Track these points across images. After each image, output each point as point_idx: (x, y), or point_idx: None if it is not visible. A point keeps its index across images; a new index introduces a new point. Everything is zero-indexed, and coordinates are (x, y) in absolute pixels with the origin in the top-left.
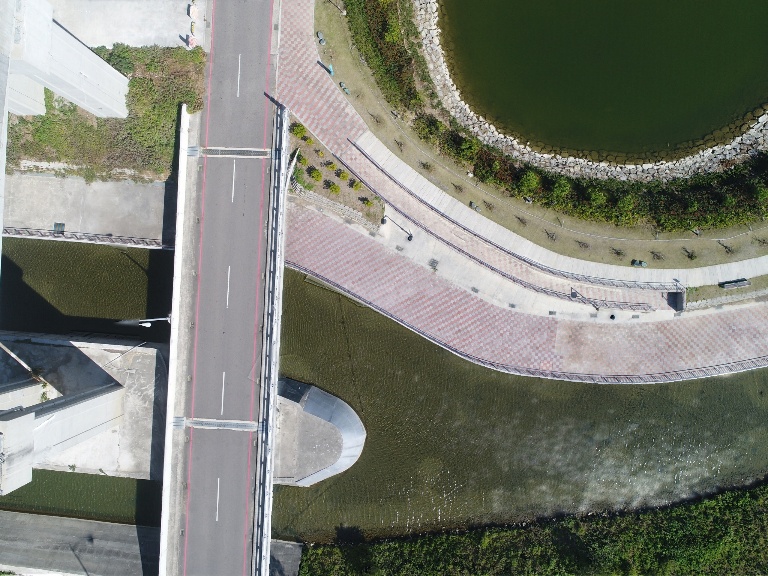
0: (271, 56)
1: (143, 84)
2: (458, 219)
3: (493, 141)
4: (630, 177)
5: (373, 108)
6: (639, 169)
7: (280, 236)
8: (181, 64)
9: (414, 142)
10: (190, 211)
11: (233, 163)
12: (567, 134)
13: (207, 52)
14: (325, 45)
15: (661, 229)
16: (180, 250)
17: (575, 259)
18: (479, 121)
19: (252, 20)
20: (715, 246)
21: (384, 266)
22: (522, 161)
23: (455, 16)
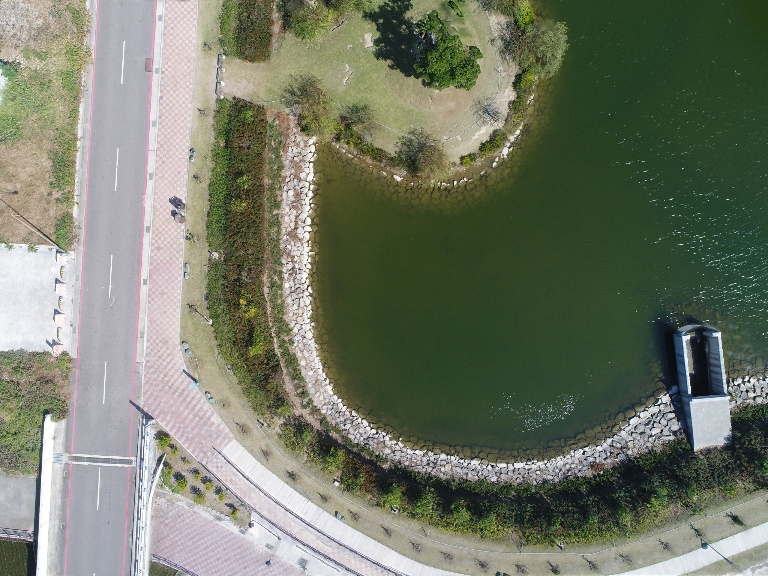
0: (137, 364)
1: (10, 388)
2: (323, 528)
3: (364, 438)
4: (500, 478)
5: (239, 417)
6: (510, 469)
7: (142, 551)
8: (47, 370)
9: (280, 451)
10: (55, 518)
11: (98, 471)
12: (441, 427)
13: (73, 357)
14: (191, 354)
15: (526, 540)
16: (44, 559)
17: (440, 570)
18: (352, 416)
19: (118, 327)
20: (579, 561)
21: (254, 564)
22: (392, 461)
23: (330, 307)
